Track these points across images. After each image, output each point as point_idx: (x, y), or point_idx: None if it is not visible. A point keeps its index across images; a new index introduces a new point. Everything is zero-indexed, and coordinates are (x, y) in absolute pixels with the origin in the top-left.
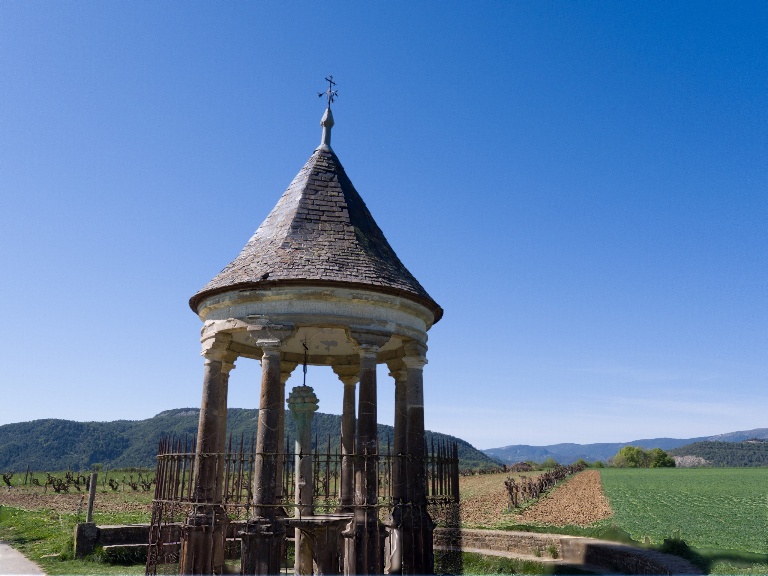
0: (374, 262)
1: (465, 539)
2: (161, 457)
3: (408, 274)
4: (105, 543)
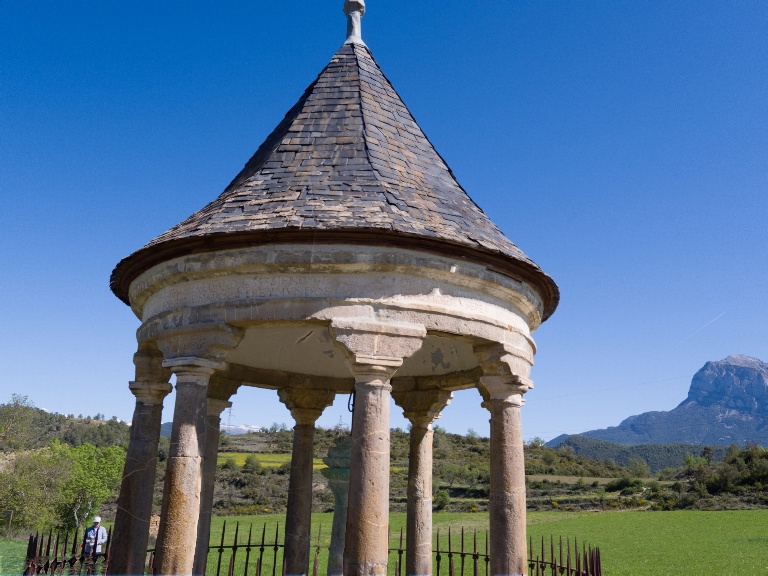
0: None
1: None
2: (572, 571)
3: None
4: None
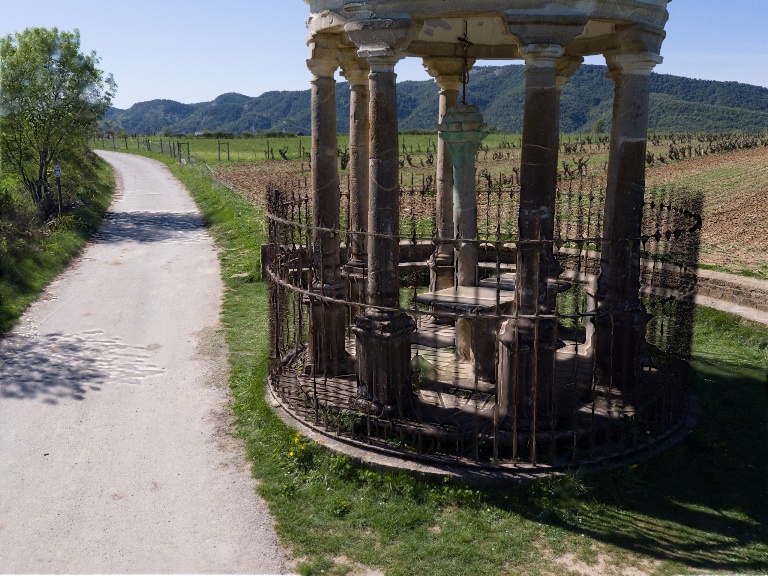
0: None
1: (720, 289)
2: None
3: None
4: (291, 265)
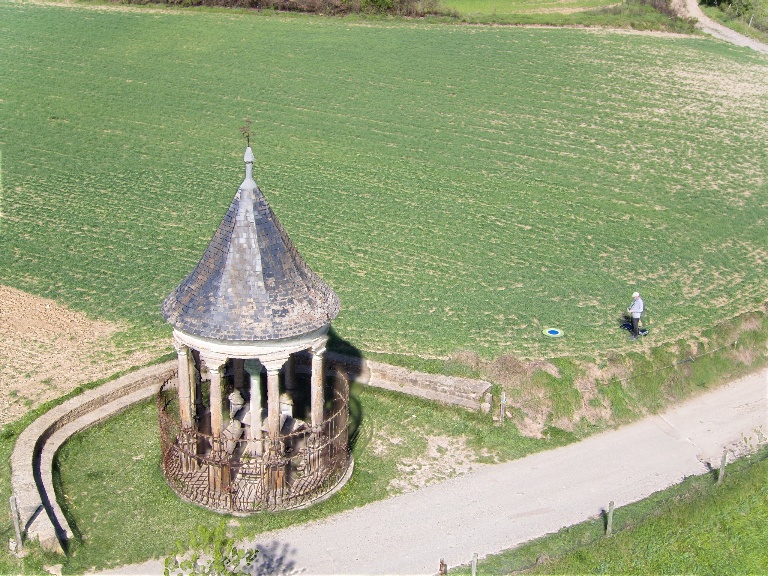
0: None
1: (147, 382)
2: None
3: None
4: None
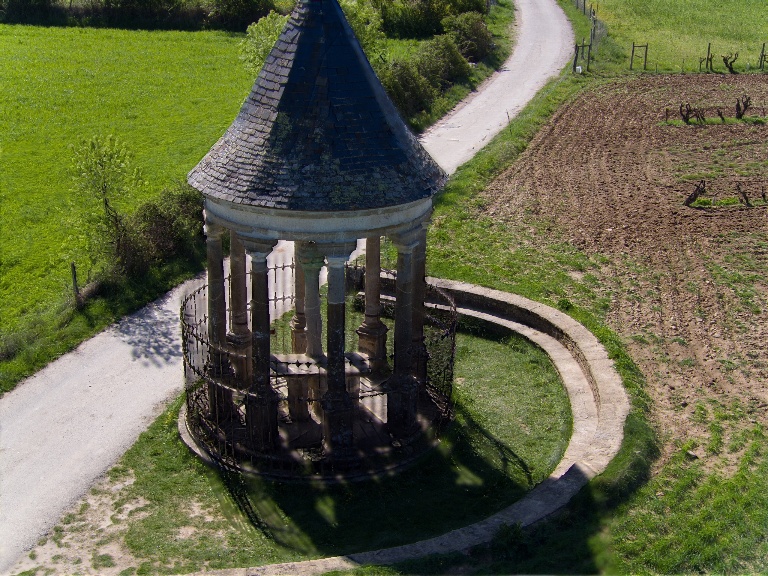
0: (264, 166)
1: None
2: None
3: (323, 167)
4: None
